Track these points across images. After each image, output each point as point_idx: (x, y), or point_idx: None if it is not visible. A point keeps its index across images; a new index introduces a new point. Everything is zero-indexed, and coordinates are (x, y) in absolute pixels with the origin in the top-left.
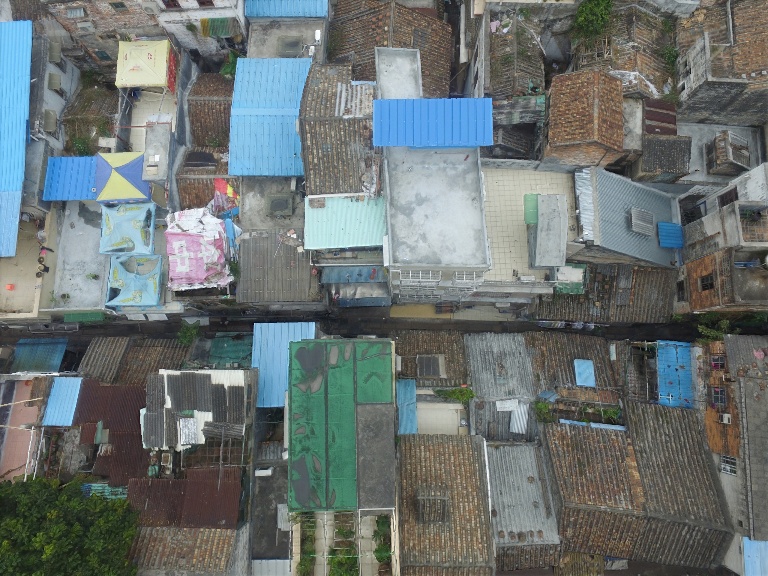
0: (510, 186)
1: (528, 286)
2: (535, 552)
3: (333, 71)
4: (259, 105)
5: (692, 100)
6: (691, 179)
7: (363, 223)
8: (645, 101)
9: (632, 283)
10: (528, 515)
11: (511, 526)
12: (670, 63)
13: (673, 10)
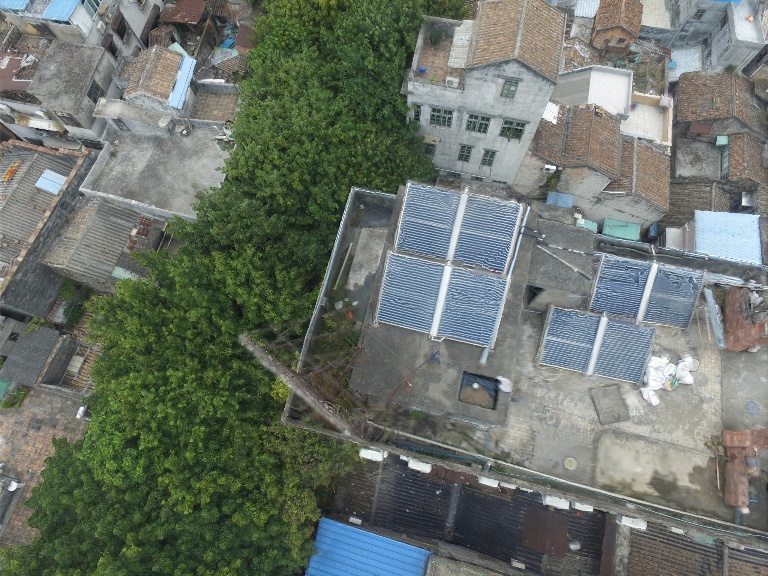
0: None
1: None
2: None
3: None
4: None
5: None
6: None
7: None
8: None
9: None
10: None
11: None
12: None
13: None
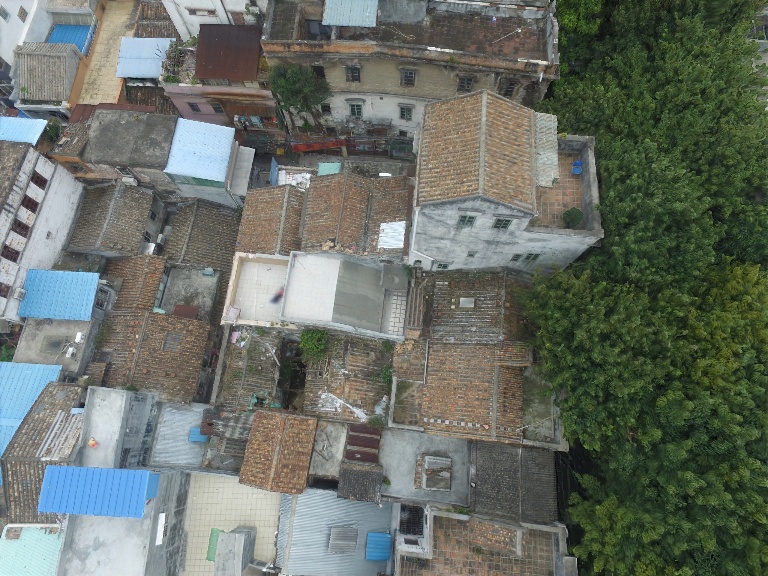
0: (228, 494)
1: None
2: None
3: (62, 394)
4: (0, 414)
5: None
6: (404, 489)
7: (46, 560)
8: (350, 426)
9: None
10: None
11: None
12: (386, 382)
13: (386, 338)
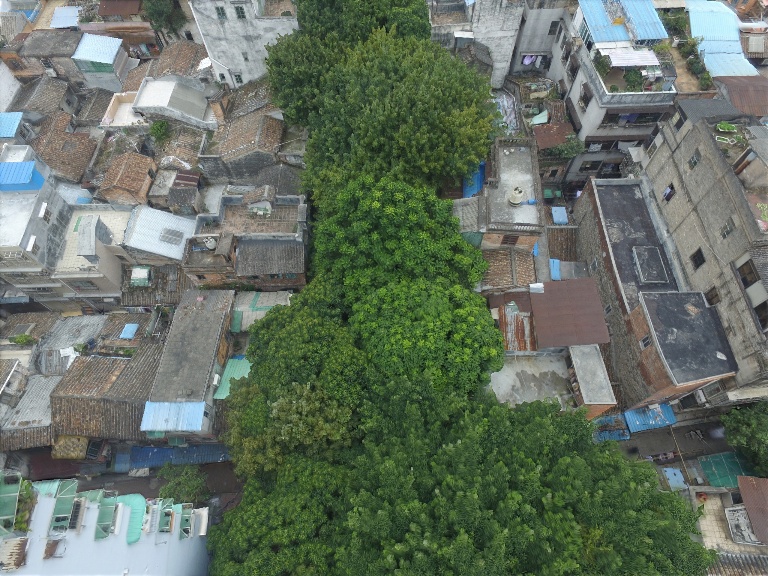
0: None
1: (86, 273)
2: (33, 434)
3: None
4: None
5: (206, 169)
6: None
7: None
8: (179, 171)
9: (177, 277)
10: (40, 412)
11: (24, 419)
12: None
13: (207, 127)
